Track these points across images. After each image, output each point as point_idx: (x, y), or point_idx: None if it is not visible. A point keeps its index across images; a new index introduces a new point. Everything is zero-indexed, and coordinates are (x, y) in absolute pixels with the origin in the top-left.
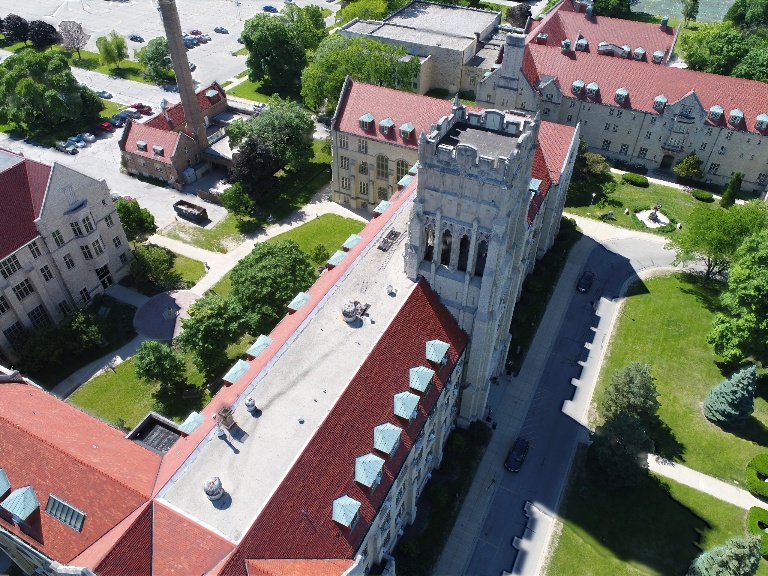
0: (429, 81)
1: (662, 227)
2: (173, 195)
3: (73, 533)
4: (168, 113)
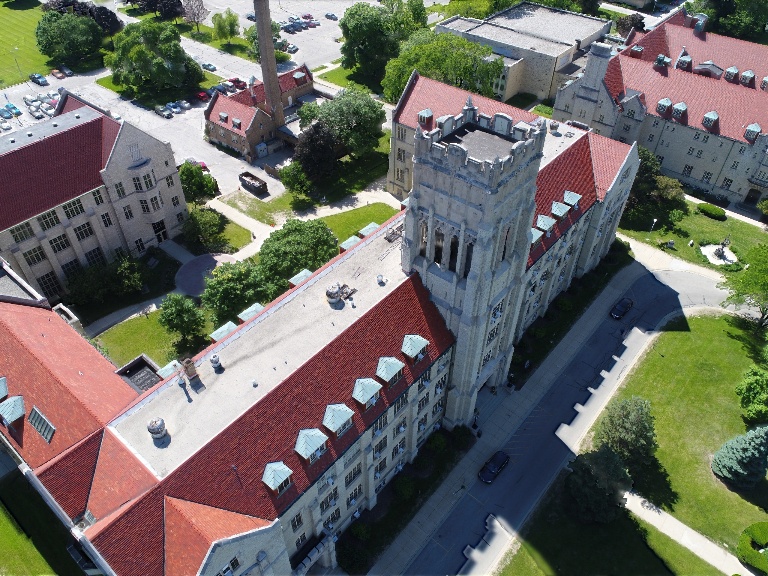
0: (518, 85)
1: (726, 265)
2: (243, 166)
3: (44, 443)
4: (254, 89)
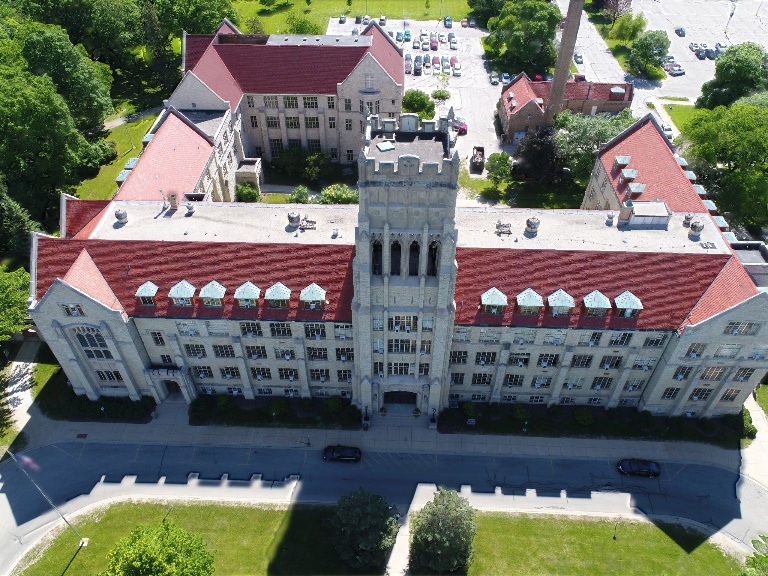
0: None
1: None
2: (492, 144)
3: None
4: None
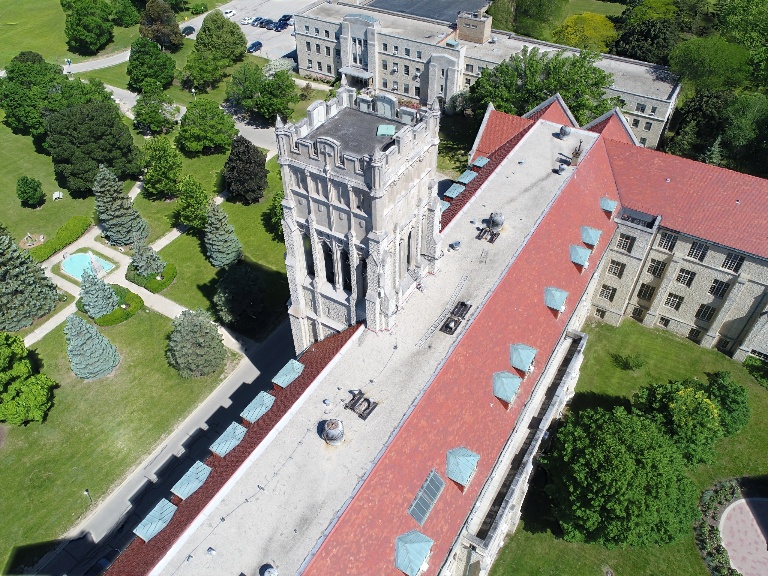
0: None
1: None
2: None
3: None
4: None
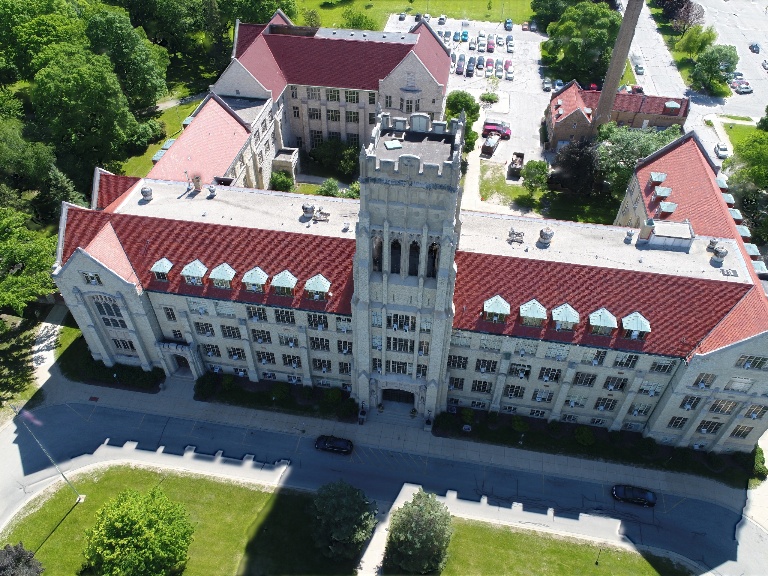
0: None
1: None
2: (534, 151)
3: None
4: None
